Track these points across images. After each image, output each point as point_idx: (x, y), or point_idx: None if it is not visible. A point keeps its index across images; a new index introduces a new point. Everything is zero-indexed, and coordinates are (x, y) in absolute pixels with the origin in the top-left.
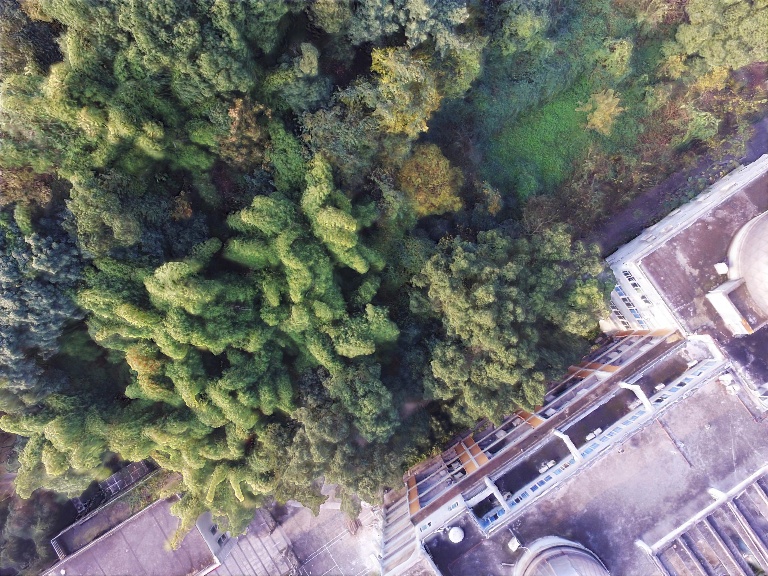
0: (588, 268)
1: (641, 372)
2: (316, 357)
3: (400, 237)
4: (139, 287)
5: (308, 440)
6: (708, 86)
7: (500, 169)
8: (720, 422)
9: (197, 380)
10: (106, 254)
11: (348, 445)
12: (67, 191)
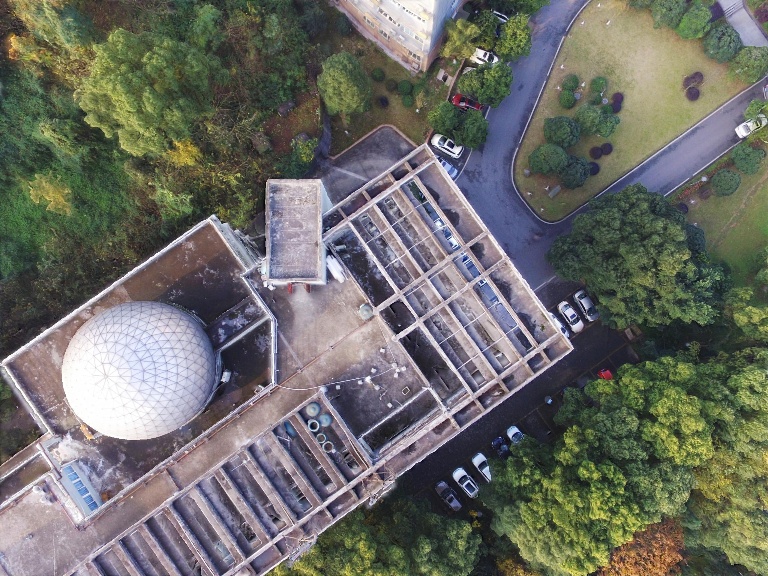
0: None
1: (4, 476)
2: None
3: None
4: None
5: None
6: (175, 162)
7: None
8: (43, 531)
9: None
10: None
11: None
12: None
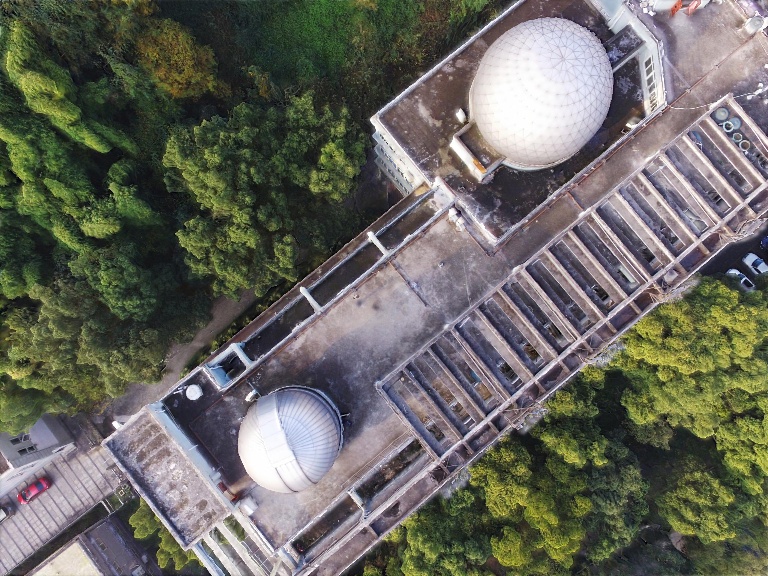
0: (334, 129)
1: (387, 225)
2: None
3: (162, 123)
4: None
5: None
6: None
7: (278, 57)
8: (453, 260)
9: None
10: None
11: (93, 321)
12: None
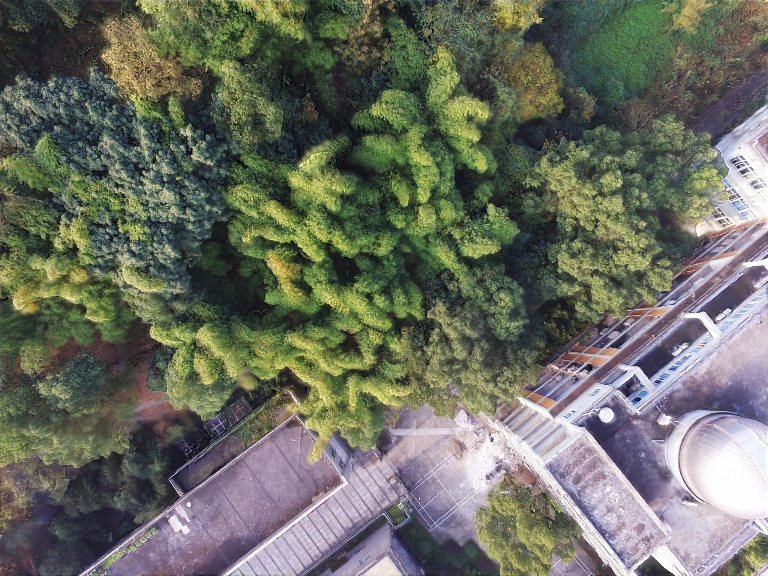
0: (702, 154)
1: (765, 250)
2: (443, 259)
3: (504, 144)
4: (280, 187)
5: (446, 338)
6: None
7: (588, 77)
8: None
9: (332, 285)
10: (253, 149)
11: (485, 341)
12: (209, 88)
